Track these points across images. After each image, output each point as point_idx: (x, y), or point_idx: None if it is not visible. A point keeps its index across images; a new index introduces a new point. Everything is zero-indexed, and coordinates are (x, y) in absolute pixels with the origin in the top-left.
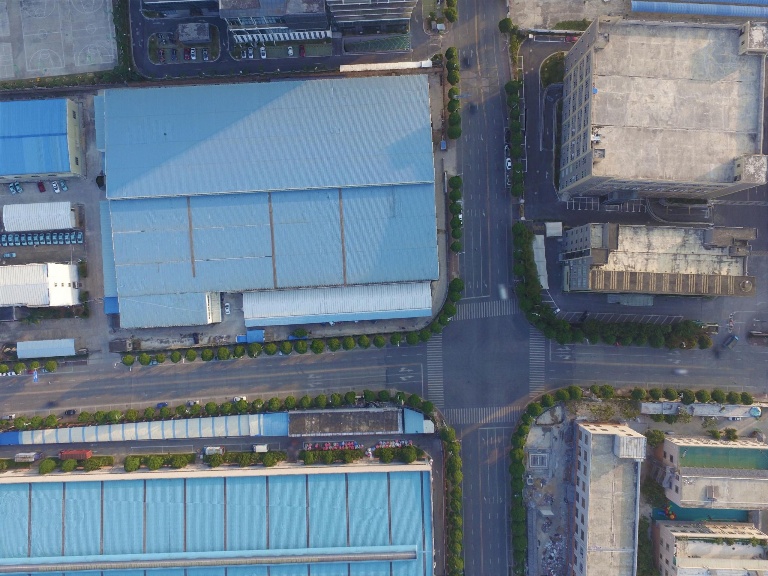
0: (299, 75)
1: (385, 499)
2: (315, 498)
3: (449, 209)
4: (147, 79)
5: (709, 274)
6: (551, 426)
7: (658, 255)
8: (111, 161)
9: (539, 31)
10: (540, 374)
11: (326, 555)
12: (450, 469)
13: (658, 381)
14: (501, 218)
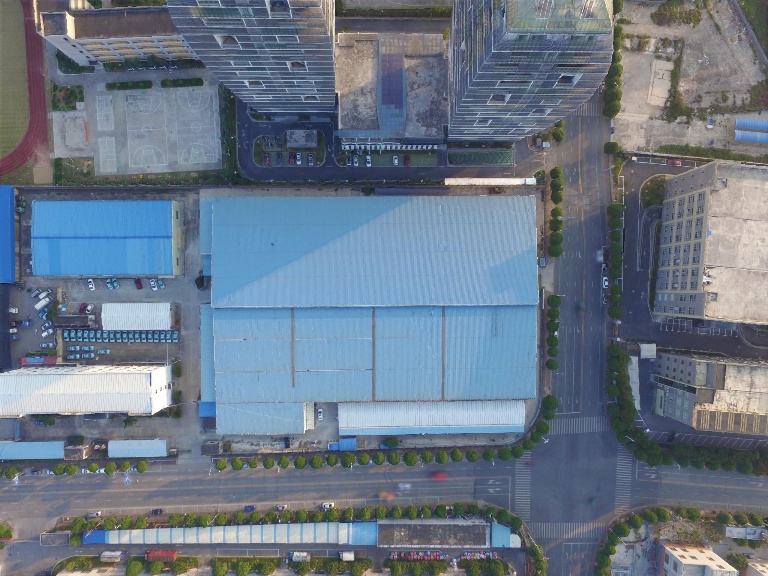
0: (404, 186)
1: None
2: None
3: (546, 326)
4: (251, 181)
5: None
6: (634, 544)
7: (760, 394)
8: (217, 269)
9: (642, 153)
10: (626, 492)
11: None
12: None
13: (741, 503)
14: (595, 336)
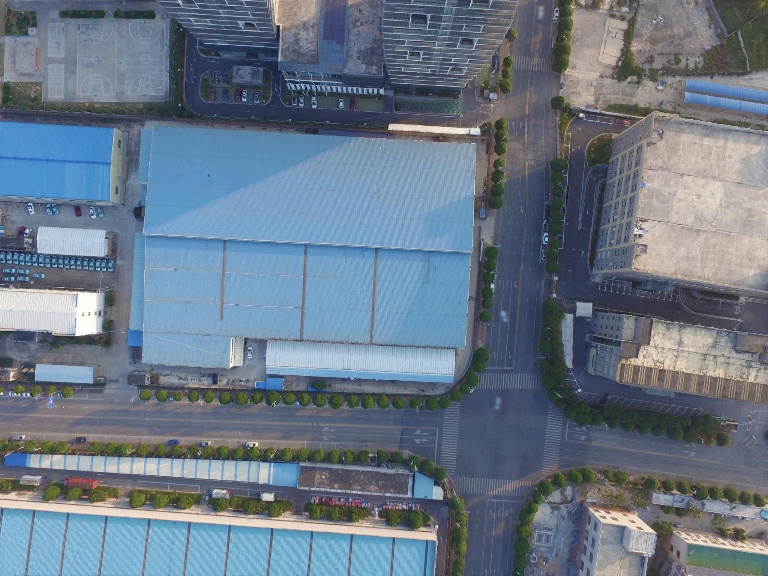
0: (347, 129)
1: (388, 564)
2: (318, 556)
3: (482, 278)
4: (196, 116)
5: (737, 379)
6: (560, 505)
7: (688, 353)
8: (152, 197)
9: (590, 111)
10: (554, 452)
11: None
12: (455, 539)
13: (671, 471)
14: (532, 292)
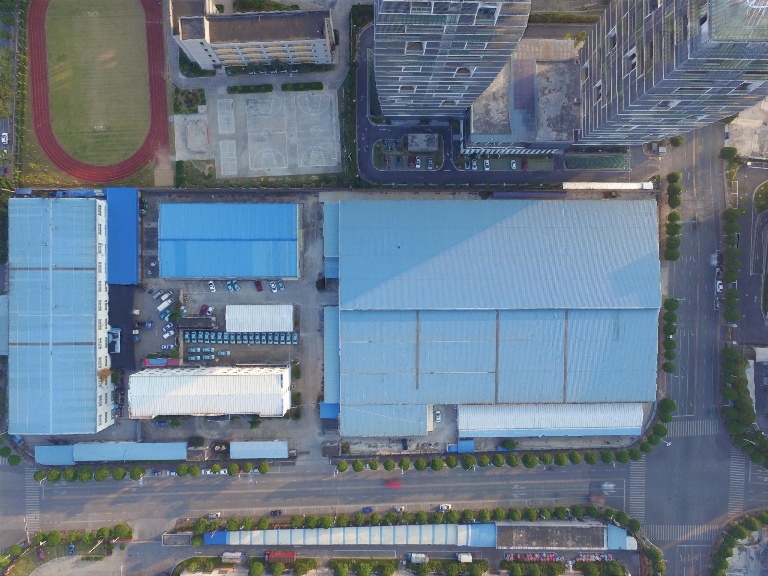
0: (522, 190)
1: None
2: None
3: (662, 329)
4: (371, 185)
5: None
6: (748, 546)
7: None
8: (345, 272)
9: (756, 158)
10: (739, 494)
11: None
12: None
13: None
14: (709, 339)
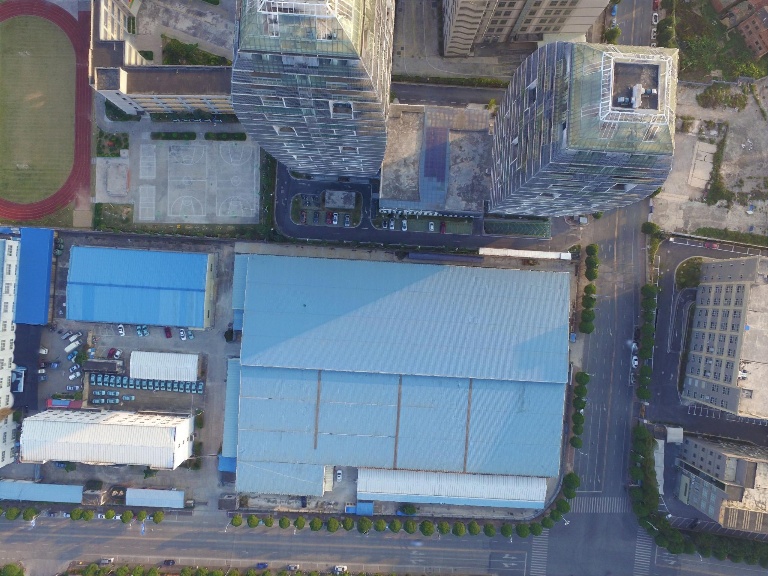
0: (438, 253)
1: None
2: None
3: (572, 403)
4: (286, 238)
5: None
6: None
7: None
8: (248, 327)
9: (679, 234)
10: None
11: None
12: None
13: None
14: (621, 415)
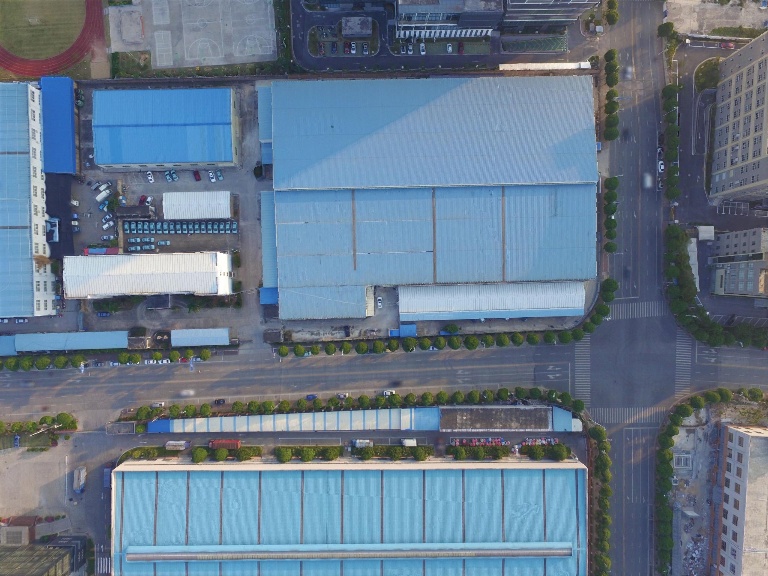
0: (459, 72)
1: (540, 496)
2: (471, 493)
3: (603, 210)
4: (306, 71)
5: None
6: (696, 428)
7: None
8: (278, 152)
9: (695, 36)
10: (686, 376)
11: (483, 550)
12: (600, 468)
13: None
14: (652, 220)
